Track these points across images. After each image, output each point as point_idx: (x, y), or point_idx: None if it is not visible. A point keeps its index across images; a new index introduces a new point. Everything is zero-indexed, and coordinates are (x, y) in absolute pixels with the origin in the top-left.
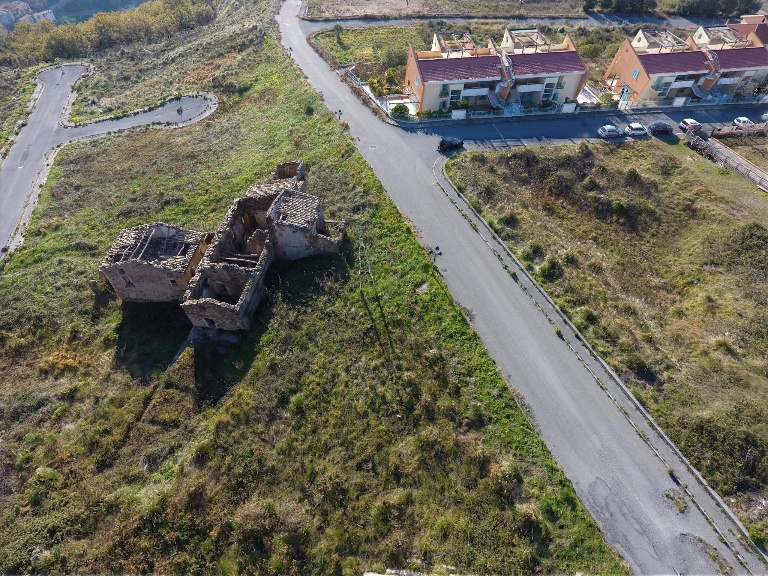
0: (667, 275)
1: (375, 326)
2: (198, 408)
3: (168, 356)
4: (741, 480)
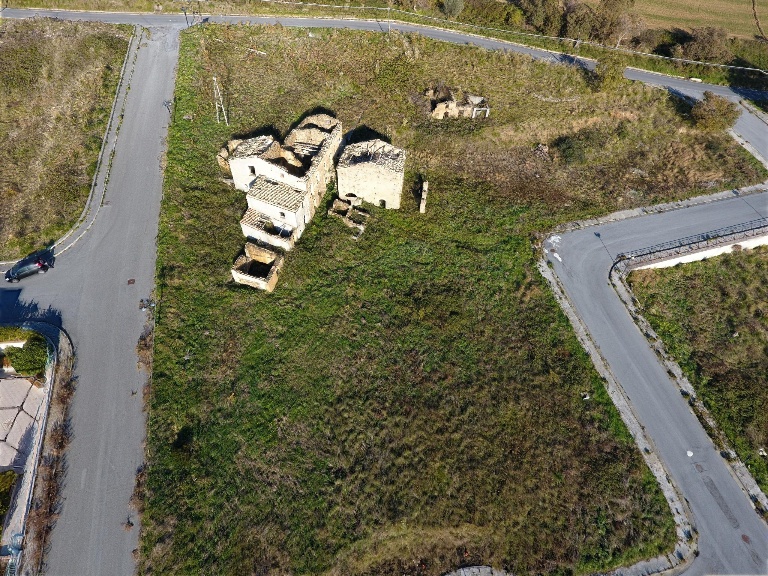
0: (3, 134)
1: (228, 107)
2: (334, 111)
3: (358, 140)
4: (117, 38)
